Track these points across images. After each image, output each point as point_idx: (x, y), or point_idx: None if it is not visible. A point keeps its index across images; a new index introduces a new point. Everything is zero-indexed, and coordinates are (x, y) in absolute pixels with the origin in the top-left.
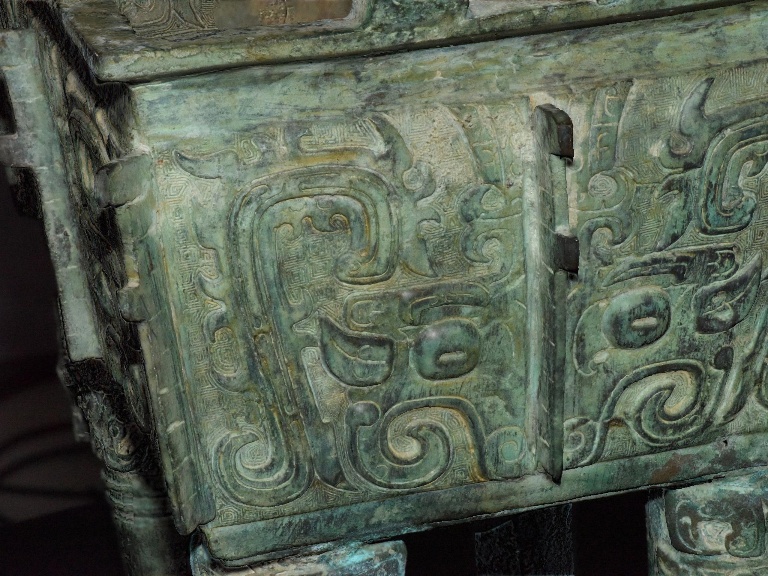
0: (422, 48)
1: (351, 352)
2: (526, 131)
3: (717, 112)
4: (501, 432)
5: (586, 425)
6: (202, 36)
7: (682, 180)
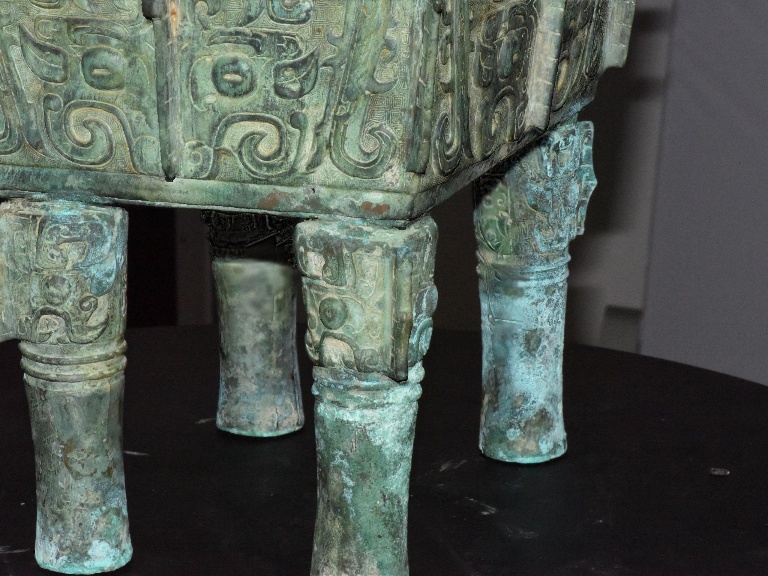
0: None
1: (40, 55)
2: None
3: None
4: (144, 138)
5: (203, 148)
6: None
7: None
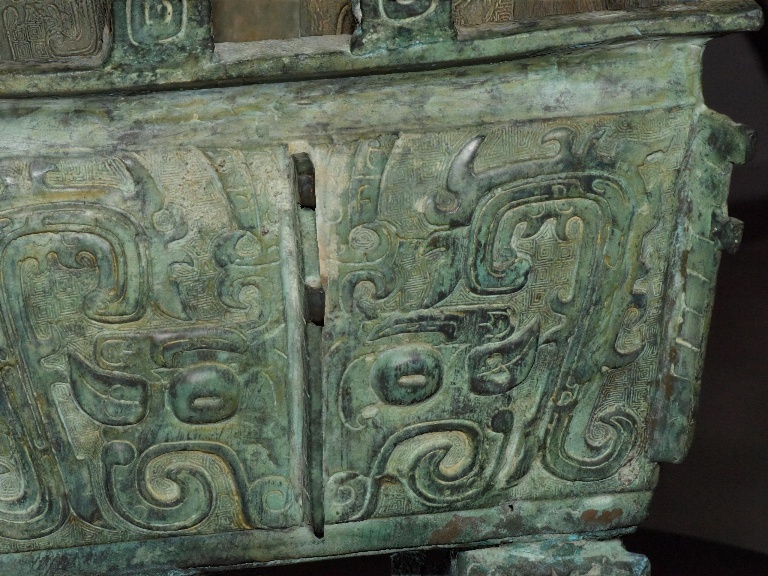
0: (165, 90)
1: (102, 390)
2: (282, 179)
3: (487, 170)
4: (265, 481)
5: (356, 480)
6: None
7: (449, 237)
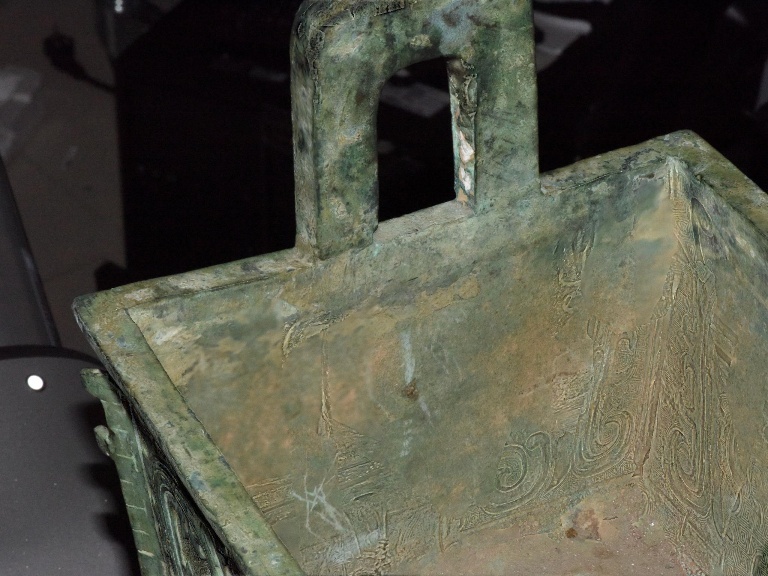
0: None
1: None
2: None
3: None
4: None
5: None
6: (634, 157)
7: None
